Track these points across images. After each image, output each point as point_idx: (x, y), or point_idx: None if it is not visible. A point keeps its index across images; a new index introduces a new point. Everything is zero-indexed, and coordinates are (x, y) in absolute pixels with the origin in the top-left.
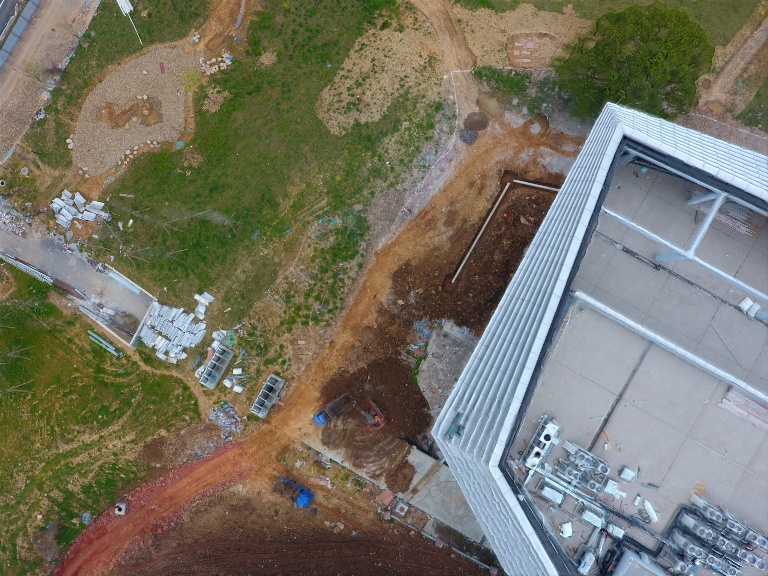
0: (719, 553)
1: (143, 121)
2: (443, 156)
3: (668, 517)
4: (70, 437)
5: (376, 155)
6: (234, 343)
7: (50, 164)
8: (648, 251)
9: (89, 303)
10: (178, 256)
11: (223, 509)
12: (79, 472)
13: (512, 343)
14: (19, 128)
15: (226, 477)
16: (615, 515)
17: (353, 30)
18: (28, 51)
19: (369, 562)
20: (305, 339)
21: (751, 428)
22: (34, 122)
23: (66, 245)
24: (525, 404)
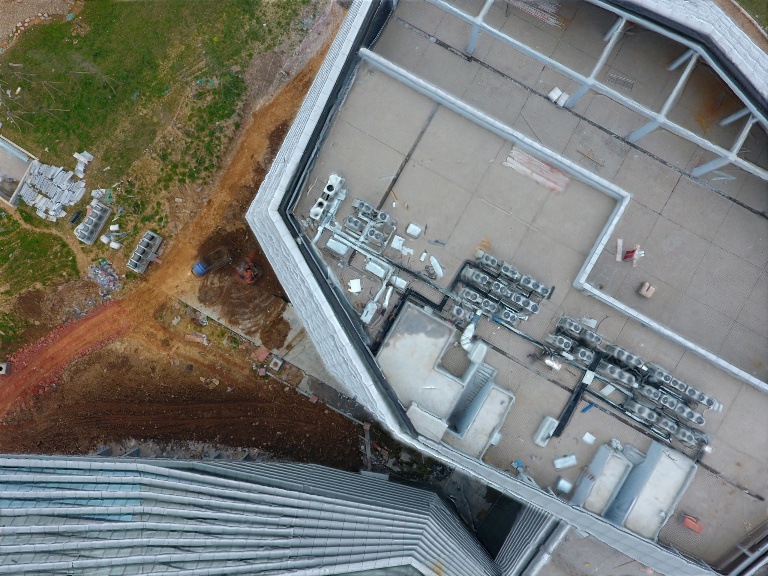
0: (495, 298)
1: None
2: (321, 21)
3: (454, 273)
4: None
5: (254, 18)
6: (112, 201)
7: None
8: (460, 43)
9: None
10: (59, 116)
11: (101, 367)
12: None
13: (307, 109)
14: None
15: (105, 335)
16: (401, 269)
17: None
18: None
19: (248, 423)
20: (182, 197)
21: (535, 186)
22: None
23: None
24: (307, 153)
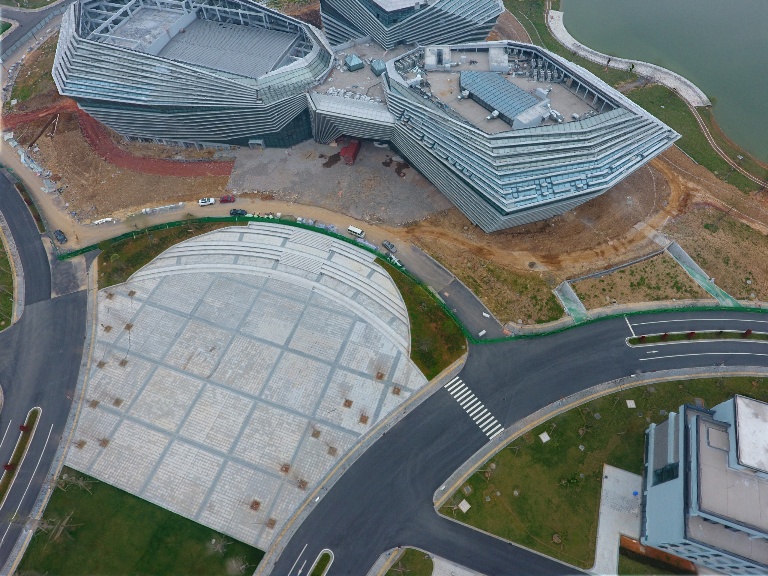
0: None
1: None
2: None
3: None
4: None
5: None
6: None
7: None
8: None
9: None
10: None
11: None
12: None
13: None
14: None
15: None
16: None
17: None
18: None
19: None
20: (292, 6)
21: None
22: None
23: None
24: None
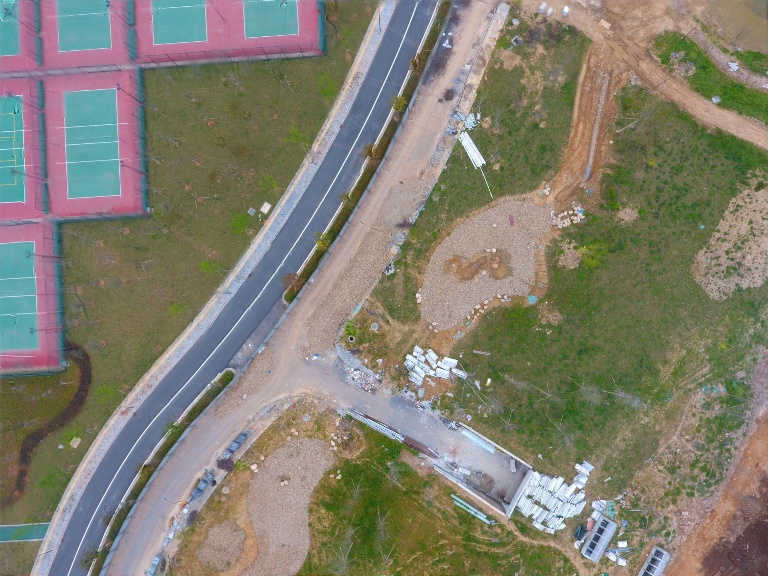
0: None
1: (491, 274)
2: None
3: None
4: None
5: (759, 321)
6: (615, 514)
7: (399, 319)
8: None
9: (442, 462)
10: None
11: None
12: None
13: None
14: (369, 283)
15: None
16: None
17: (725, 190)
18: (376, 204)
19: None
20: (688, 509)
21: None
22: (384, 277)
23: (418, 402)
24: None
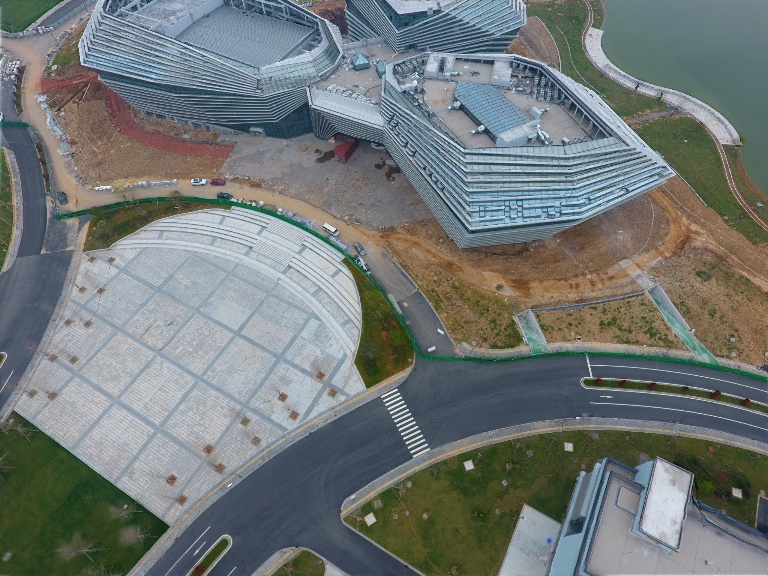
0: None
1: None
2: None
3: None
4: None
5: None
6: None
7: None
8: None
9: None
10: None
11: None
12: None
13: None
14: None
15: None
16: None
17: None
18: None
19: None
20: (327, 0)
21: None
22: None
23: None
24: None
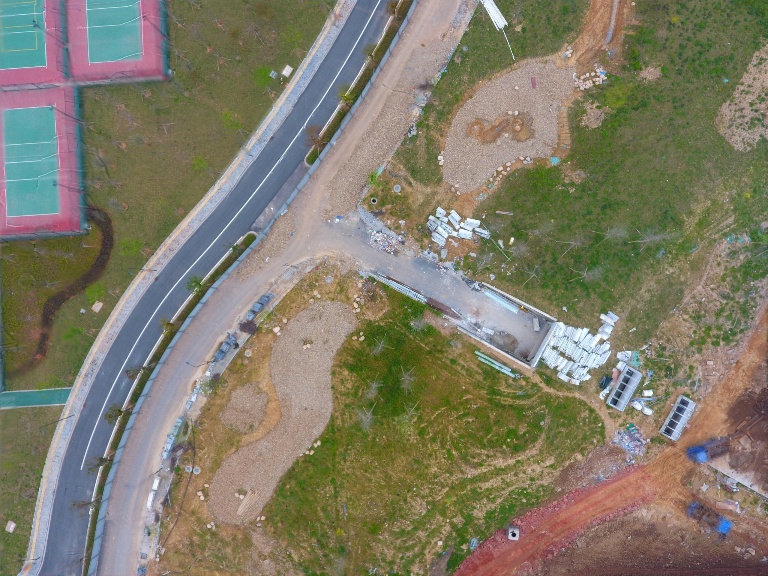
0: None
1: (514, 137)
2: None
3: None
4: (476, 461)
5: None
6: (640, 364)
7: (422, 181)
8: None
9: (465, 322)
10: None
11: (624, 534)
12: (488, 497)
13: None
14: (392, 145)
15: (628, 501)
16: None
17: (749, 44)
18: (398, 67)
19: None
20: (713, 359)
21: None
22: (406, 139)
23: (441, 263)
24: None
